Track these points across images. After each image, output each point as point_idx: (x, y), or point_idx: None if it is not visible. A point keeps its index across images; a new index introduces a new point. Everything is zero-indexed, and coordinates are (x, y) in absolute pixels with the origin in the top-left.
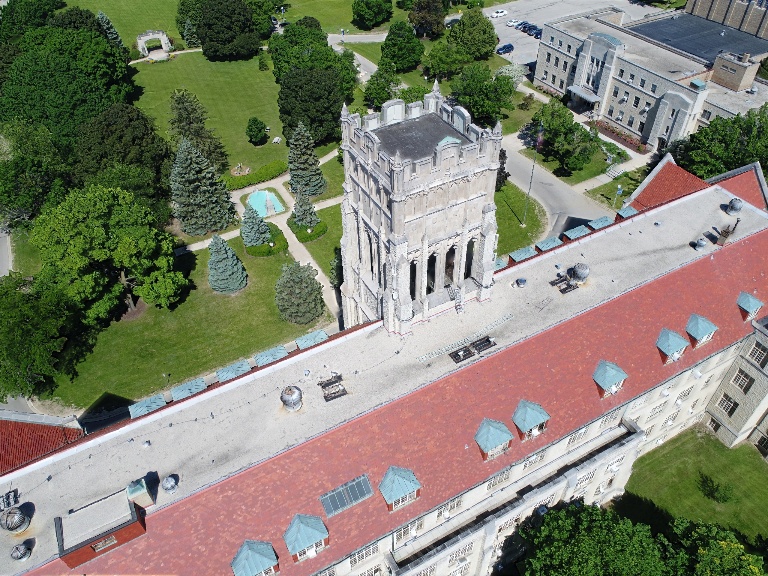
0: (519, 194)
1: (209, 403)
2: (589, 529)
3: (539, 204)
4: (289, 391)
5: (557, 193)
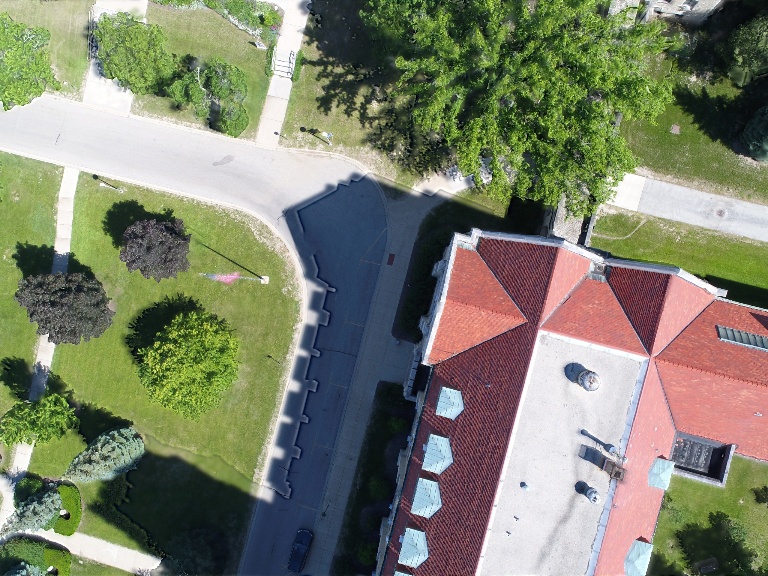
0: (211, 217)
1: None
2: None
3: (248, 216)
4: None
5: (250, 172)
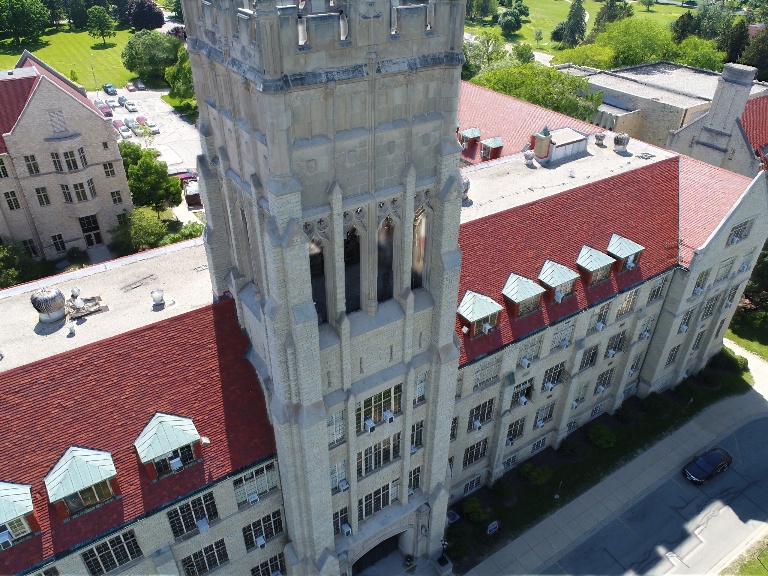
0: None
1: (542, 195)
2: None
3: None
4: None
5: None
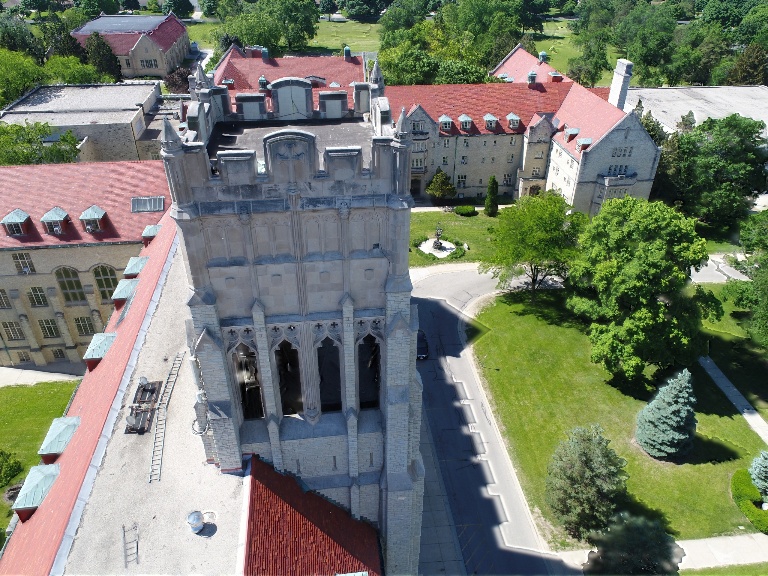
0: None
1: None
2: None
3: None
4: None
5: None
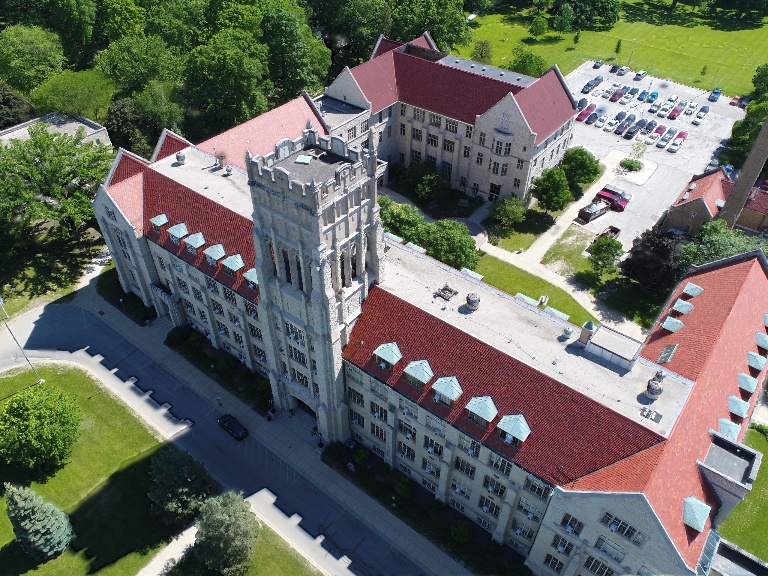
0: None
1: (504, 347)
2: (421, 242)
3: None
4: (475, 294)
5: None
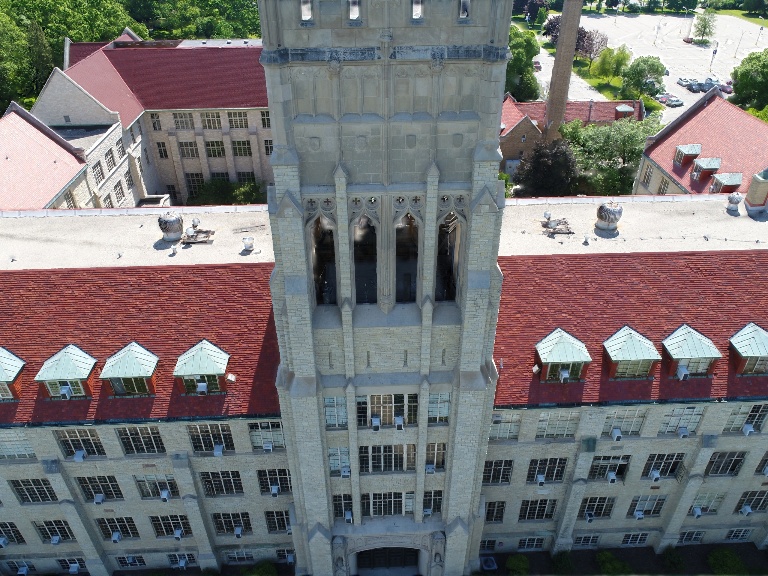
0: None
1: (714, 247)
2: None
3: None
4: None
5: None
